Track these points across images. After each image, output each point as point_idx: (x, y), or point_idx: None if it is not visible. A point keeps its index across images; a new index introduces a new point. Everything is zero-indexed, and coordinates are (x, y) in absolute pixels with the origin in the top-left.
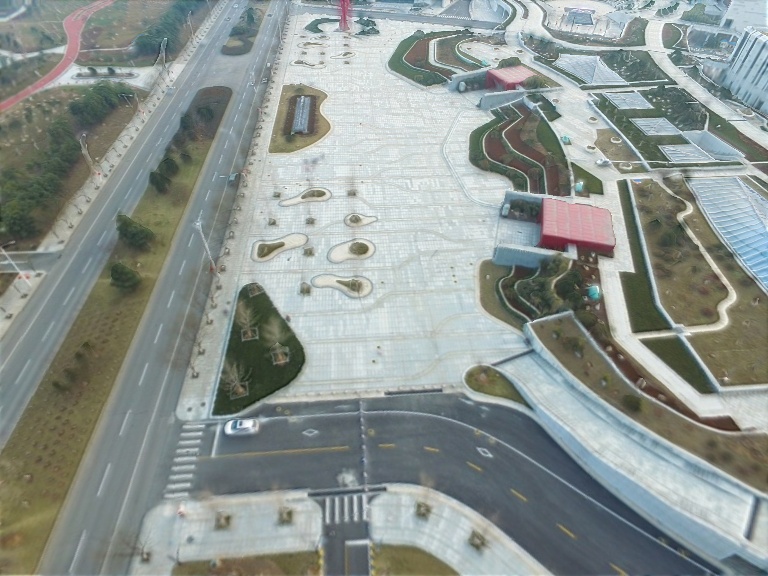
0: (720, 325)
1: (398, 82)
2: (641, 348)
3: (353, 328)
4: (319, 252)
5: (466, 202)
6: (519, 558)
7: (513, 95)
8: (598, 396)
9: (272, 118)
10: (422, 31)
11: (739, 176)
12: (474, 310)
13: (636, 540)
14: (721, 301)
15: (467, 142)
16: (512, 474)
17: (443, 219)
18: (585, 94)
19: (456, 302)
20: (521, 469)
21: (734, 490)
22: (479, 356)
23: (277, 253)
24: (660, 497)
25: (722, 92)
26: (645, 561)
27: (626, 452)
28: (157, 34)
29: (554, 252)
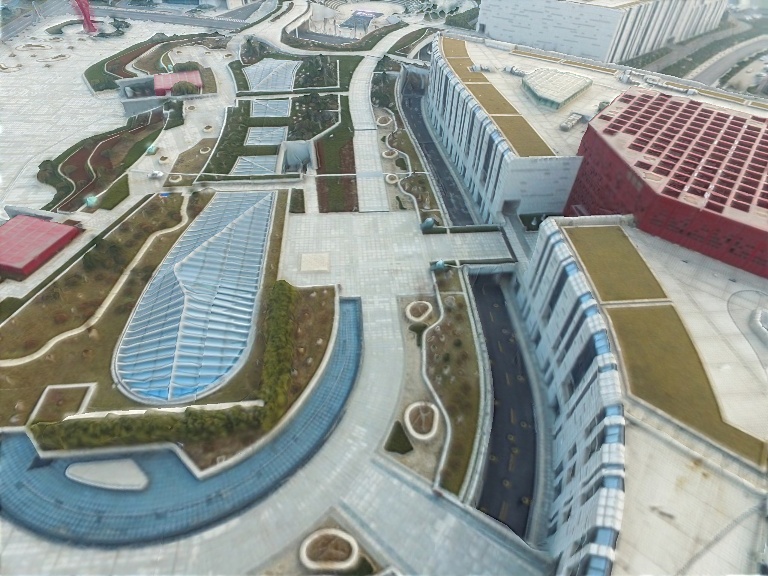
0: (26, 359)
1: (77, 87)
2: None
3: None
4: None
5: None
6: None
7: (156, 102)
8: None
9: None
10: (162, 33)
11: (280, 190)
12: None
13: None
14: (66, 331)
15: (64, 151)
16: None
17: None
18: (232, 101)
19: None
20: None
21: None
22: None
23: None
24: None
25: (380, 100)
26: None
27: None
28: None
29: None
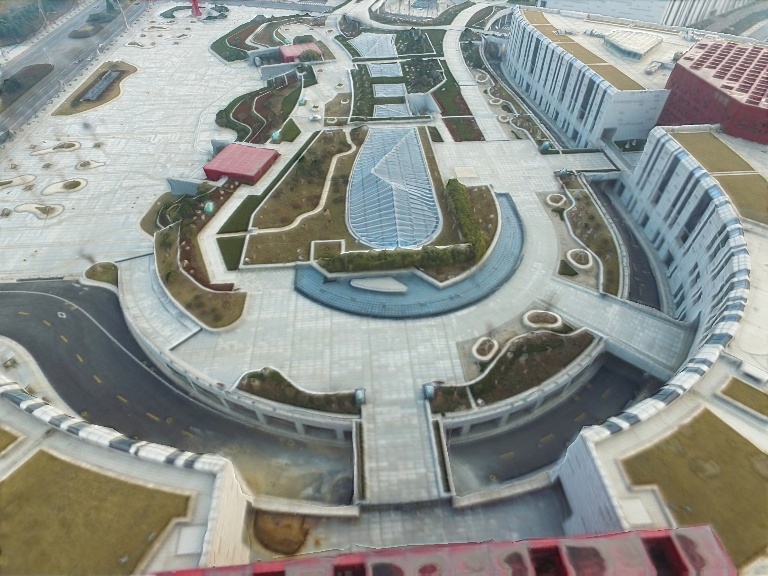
0: (287, 228)
1: (209, 59)
2: (212, 243)
3: (25, 239)
4: (37, 188)
5: (189, 151)
6: (32, 373)
7: (288, 67)
8: (159, 275)
9: (74, 89)
10: (262, 15)
11: (418, 127)
12: (131, 226)
13: (125, 363)
14: (305, 213)
15: None
16: (70, 327)
17: (159, 164)
18: (351, 65)
19: (122, 221)
20: (80, 324)
21: (191, 325)
22: (110, 256)
23: (1, 188)
24: (138, 330)
25: (474, 62)
26: (120, 374)
27: (148, 308)
28: (12, 20)
29: (204, 181)
